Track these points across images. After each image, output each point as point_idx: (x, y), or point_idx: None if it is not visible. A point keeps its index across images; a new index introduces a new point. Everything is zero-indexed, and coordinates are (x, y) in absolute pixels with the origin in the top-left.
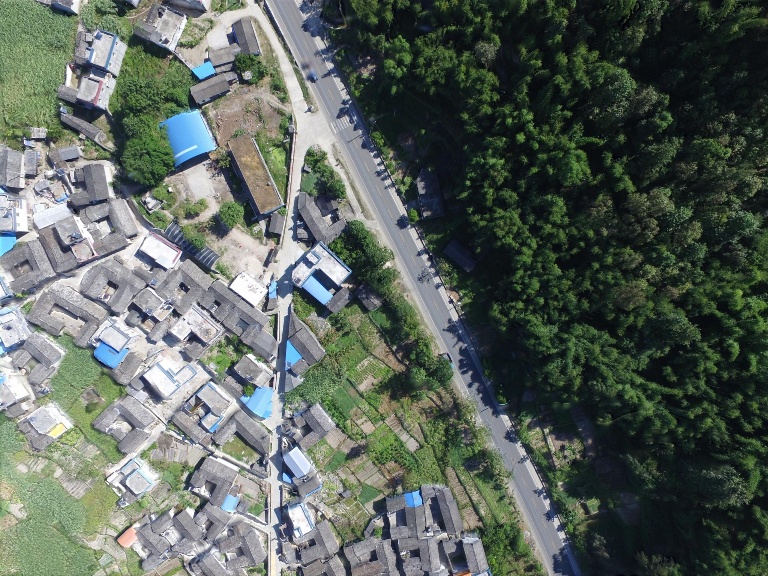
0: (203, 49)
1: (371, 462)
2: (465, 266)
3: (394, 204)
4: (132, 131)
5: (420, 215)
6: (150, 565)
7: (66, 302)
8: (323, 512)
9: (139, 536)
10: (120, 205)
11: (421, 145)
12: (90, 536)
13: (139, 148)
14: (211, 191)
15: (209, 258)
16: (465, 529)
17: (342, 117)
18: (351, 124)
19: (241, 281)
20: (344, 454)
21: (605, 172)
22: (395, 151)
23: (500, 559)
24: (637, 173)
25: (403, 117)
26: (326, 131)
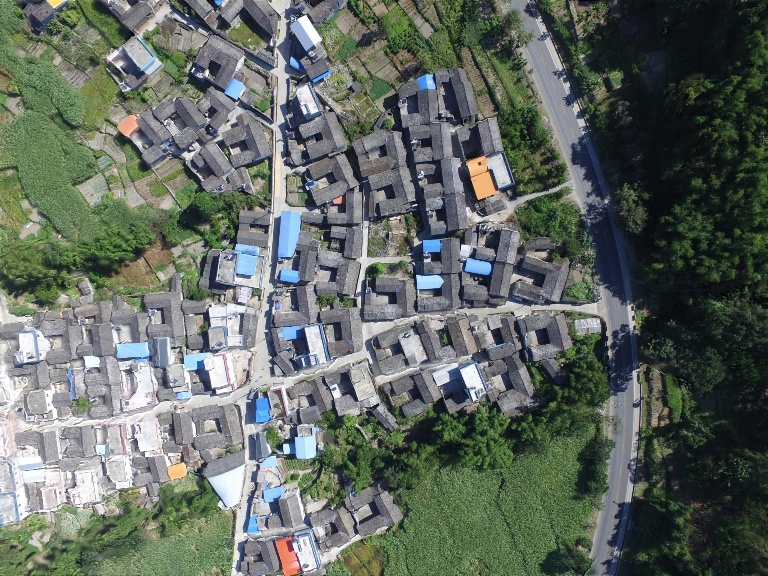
0: None
1: (383, 52)
2: None
3: None
4: None
5: None
6: (150, 154)
7: None
8: (331, 106)
9: (140, 122)
10: None
11: None
12: (89, 133)
13: None
14: None
15: None
16: (480, 117)
17: None
18: None
19: None
20: (355, 41)
21: None
22: None
23: (515, 152)
24: None
25: None
26: None
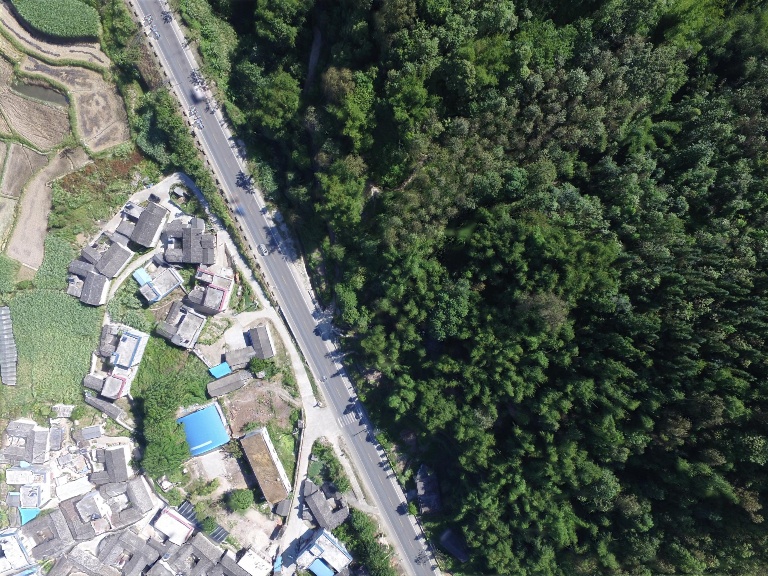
0: (220, 345)
1: None
2: (460, 557)
3: (395, 493)
4: (152, 440)
5: (419, 509)
6: None
7: (84, 567)
8: None
9: None
10: (138, 484)
11: (422, 443)
12: None
13: (158, 454)
14: (223, 471)
15: (219, 535)
16: None
17: (348, 413)
18: (357, 419)
19: (248, 559)
20: None
21: (591, 544)
22: (397, 445)
23: None
24: (620, 551)
25: (406, 419)
26: (333, 425)
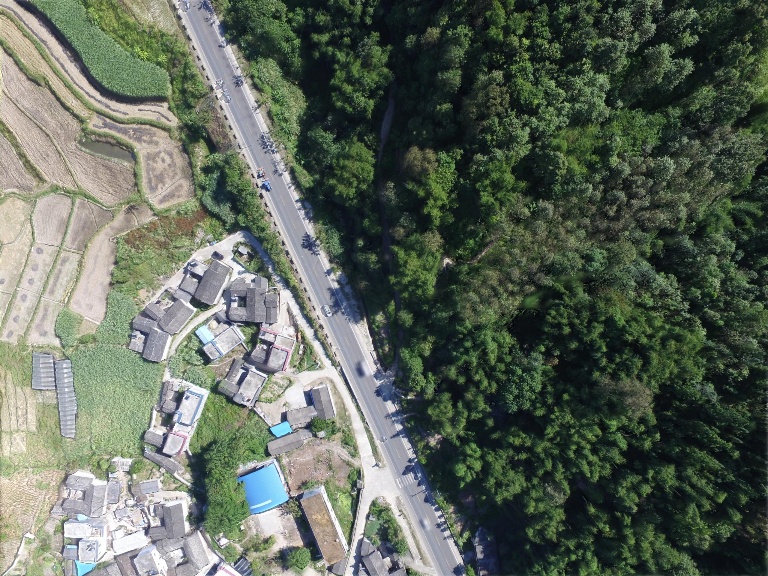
0: (281, 404)
1: None
2: None
3: (452, 554)
4: (215, 500)
5: (477, 572)
6: None
7: None
8: None
9: None
10: (194, 539)
11: (481, 506)
12: None
13: (220, 515)
14: (279, 528)
15: None
16: None
17: (407, 474)
18: (415, 480)
19: None
20: None
21: None
22: (455, 506)
23: None
24: None
25: None
26: (392, 485)
